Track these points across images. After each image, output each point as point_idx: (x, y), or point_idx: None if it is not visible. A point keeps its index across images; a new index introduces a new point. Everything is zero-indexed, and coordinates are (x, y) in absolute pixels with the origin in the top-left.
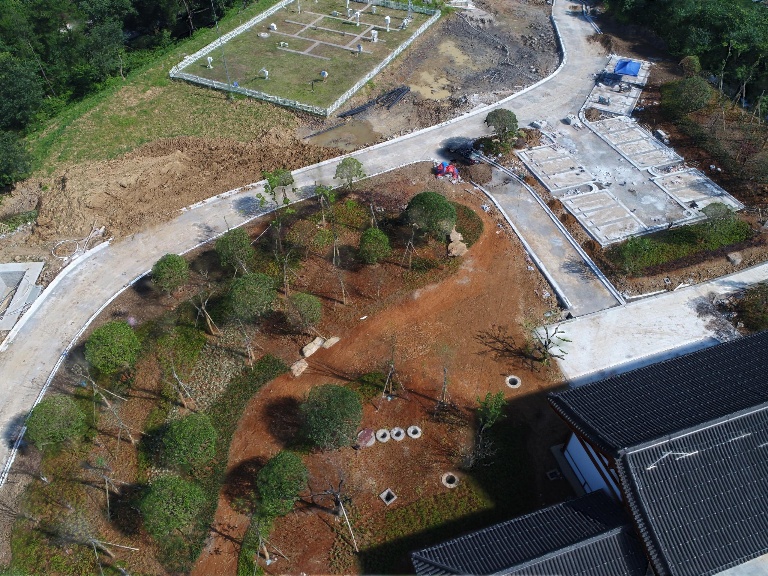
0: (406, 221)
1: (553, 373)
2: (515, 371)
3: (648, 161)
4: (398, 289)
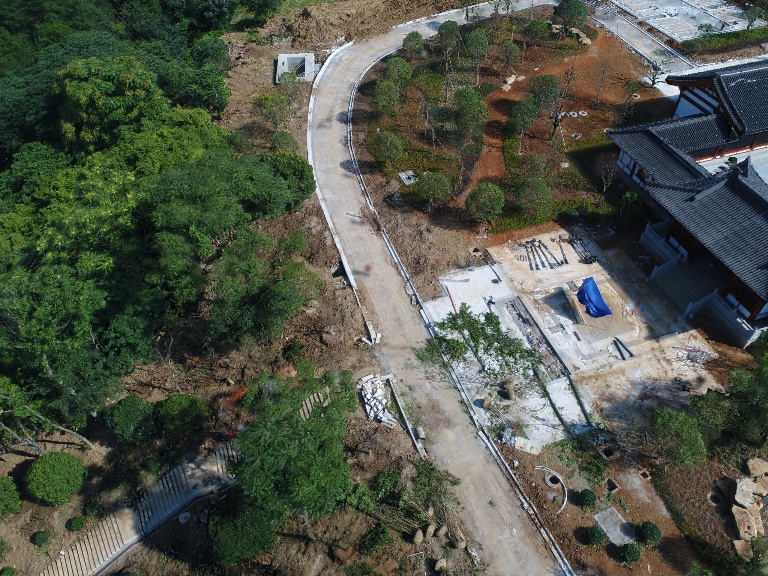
0: (548, 28)
1: (658, 93)
2: (635, 92)
3: (702, 3)
4: (553, 58)
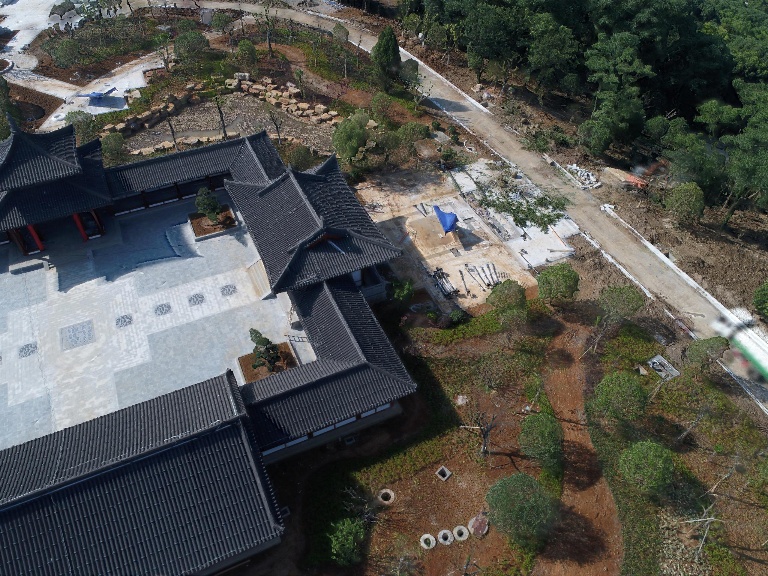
0: None
1: None
2: None
3: None
4: None
